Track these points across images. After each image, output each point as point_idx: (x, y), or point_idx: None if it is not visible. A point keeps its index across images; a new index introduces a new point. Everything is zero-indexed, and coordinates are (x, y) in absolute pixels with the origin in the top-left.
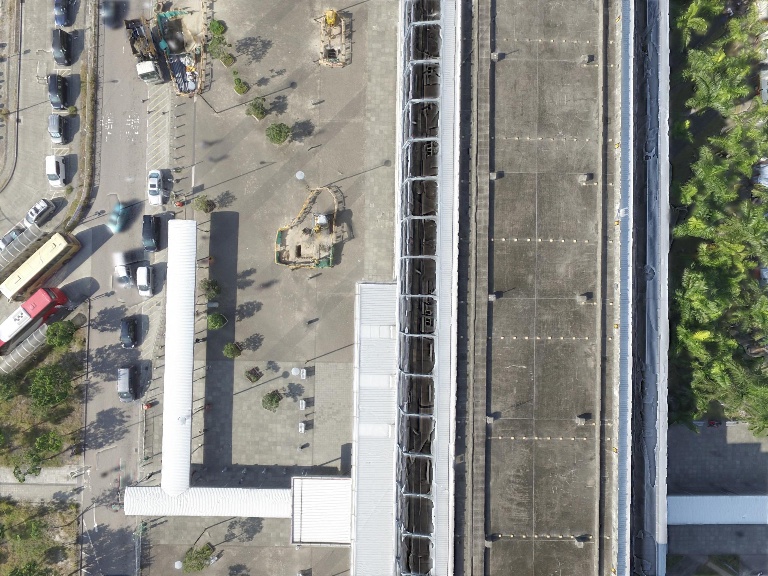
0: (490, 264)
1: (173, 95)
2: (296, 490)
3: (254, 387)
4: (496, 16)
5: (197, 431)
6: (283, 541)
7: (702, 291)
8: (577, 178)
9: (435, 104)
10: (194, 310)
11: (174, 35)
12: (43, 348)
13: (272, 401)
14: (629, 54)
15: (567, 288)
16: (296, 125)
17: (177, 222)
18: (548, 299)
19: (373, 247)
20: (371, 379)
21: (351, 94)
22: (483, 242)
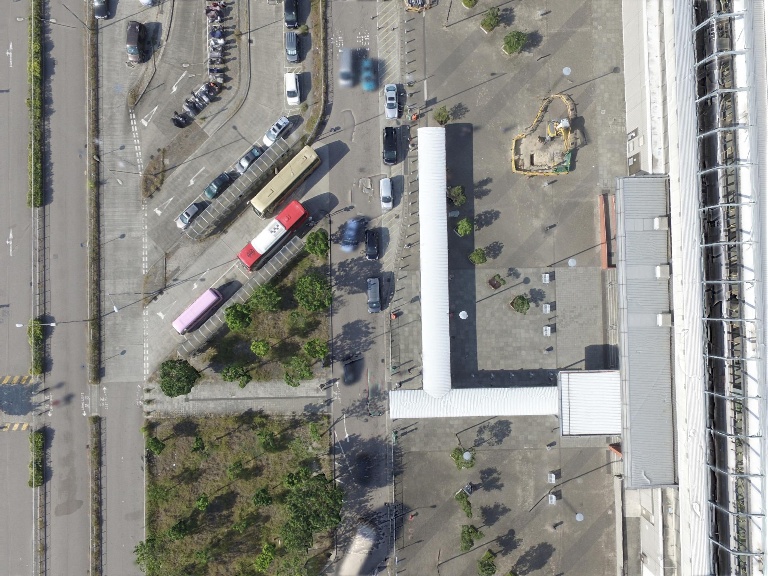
0: None
1: (402, 11)
2: (563, 384)
3: (496, 294)
4: None
5: None
6: (532, 443)
7: None
8: None
9: None
10: (446, 216)
11: None
12: (287, 264)
13: (524, 303)
14: None
15: None
16: None
17: (427, 129)
18: None
19: (607, 152)
20: (637, 271)
21: (577, 4)
22: None
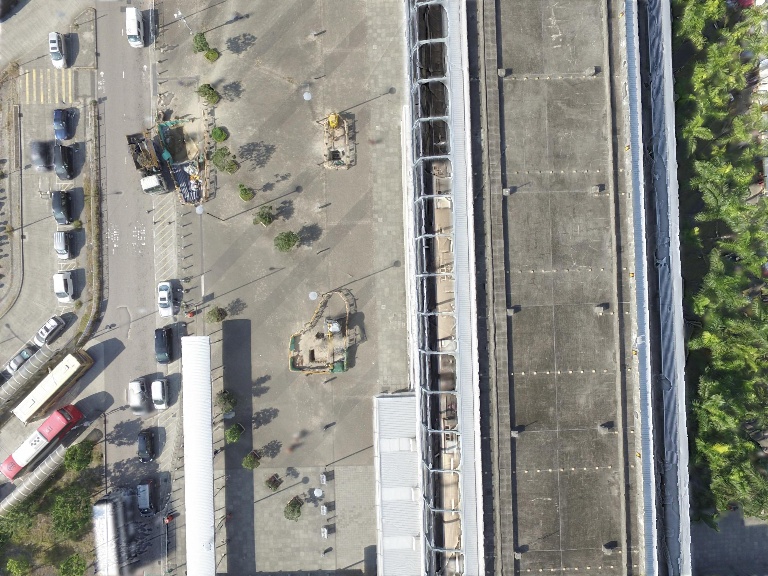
0: (511, 398)
1: (178, 204)
2: None
3: (274, 494)
4: (506, 149)
5: (219, 541)
6: None
7: (719, 404)
8: (593, 308)
9: (449, 238)
10: (211, 426)
11: (176, 143)
12: (60, 466)
13: (294, 511)
14: (639, 181)
15: (588, 418)
16: (304, 229)
17: (190, 339)
18: (570, 430)
19: (386, 349)
20: (393, 492)
21: (357, 196)
22: (503, 378)
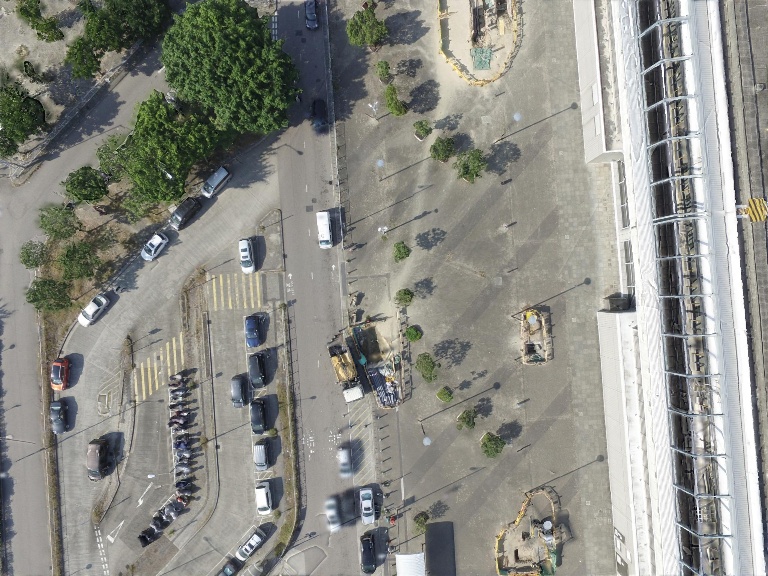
0: None
1: (374, 406)
2: None
3: None
4: None
5: None
6: None
7: None
8: None
9: (724, 499)
10: None
11: (369, 344)
12: None
13: None
14: None
15: None
16: (503, 427)
17: (405, 557)
18: None
19: (593, 546)
20: None
21: (556, 390)
22: None
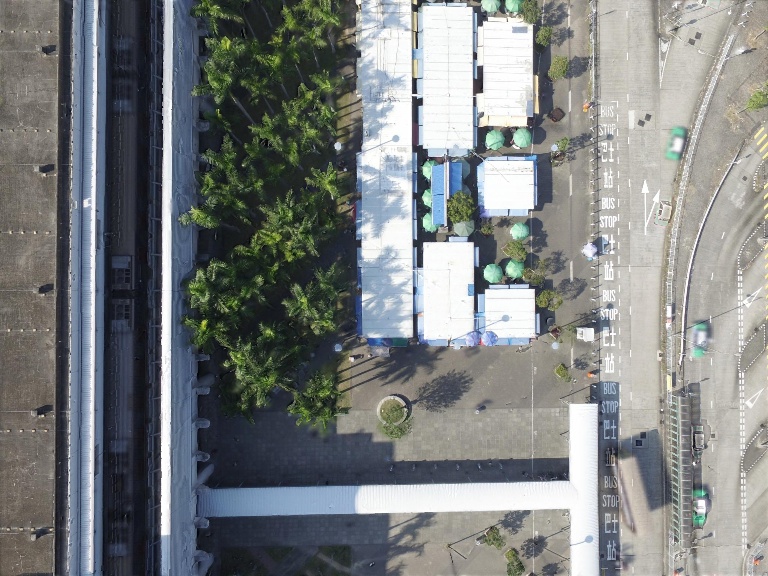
0: None
1: None
2: None
3: None
4: None
5: None
6: None
7: (203, 280)
8: None
9: None
10: None
11: None
12: None
13: None
14: (93, 43)
15: (27, 280)
16: None
17: None
18: (8, 291)
19: None
20: None
21: None
22: None
